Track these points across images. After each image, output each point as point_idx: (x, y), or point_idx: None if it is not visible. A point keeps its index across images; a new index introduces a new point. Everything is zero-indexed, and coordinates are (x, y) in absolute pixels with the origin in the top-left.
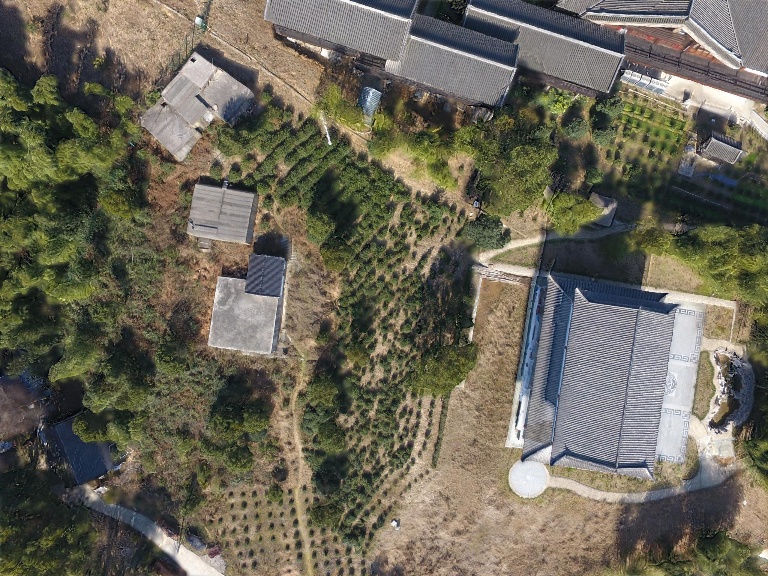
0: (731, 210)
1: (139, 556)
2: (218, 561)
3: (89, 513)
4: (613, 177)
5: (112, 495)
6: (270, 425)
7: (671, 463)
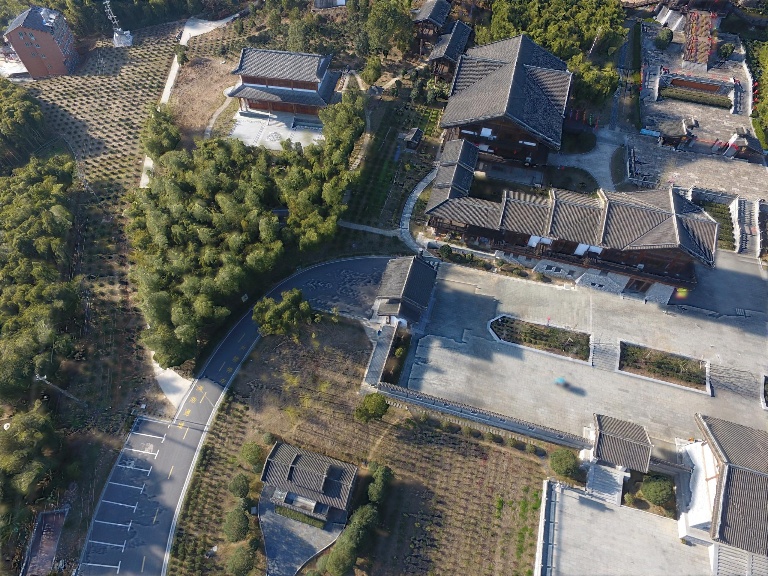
0: None
1: (235, 2)
2: (224, 26)
3: (255, 0)
4: (395, 106)
5: (261, 3)
6: (282, 19)
7: (225, 139)
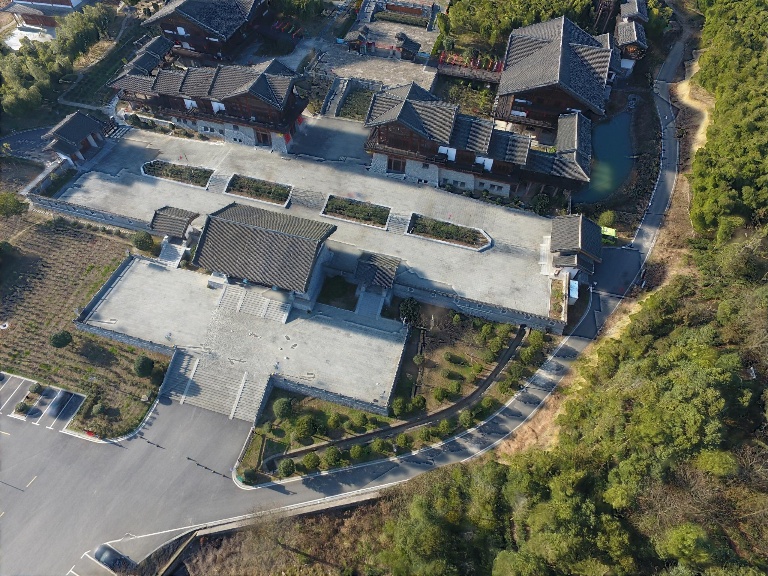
0: (114, 58)
1: None
2: None
3: None
4: None
5: None
6: None
7: None
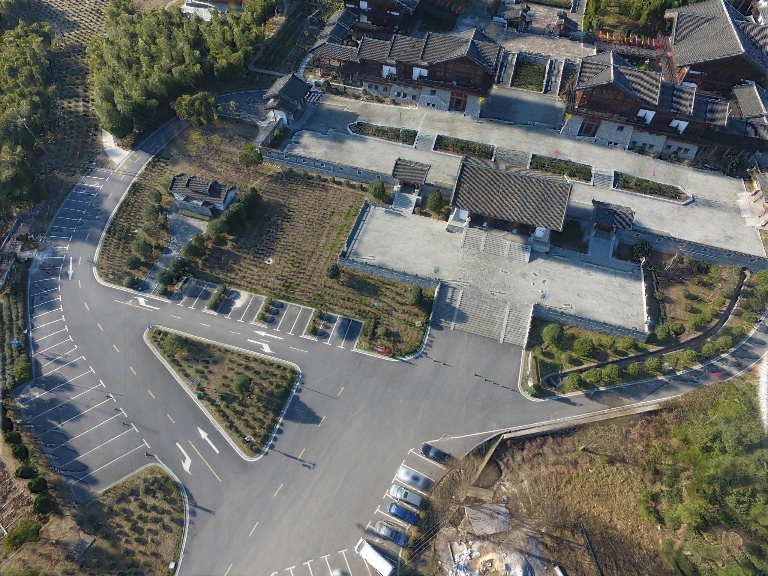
0: None
1: None
2: None
3: None
4: (308, 0)
5: None
6: None
7: None
